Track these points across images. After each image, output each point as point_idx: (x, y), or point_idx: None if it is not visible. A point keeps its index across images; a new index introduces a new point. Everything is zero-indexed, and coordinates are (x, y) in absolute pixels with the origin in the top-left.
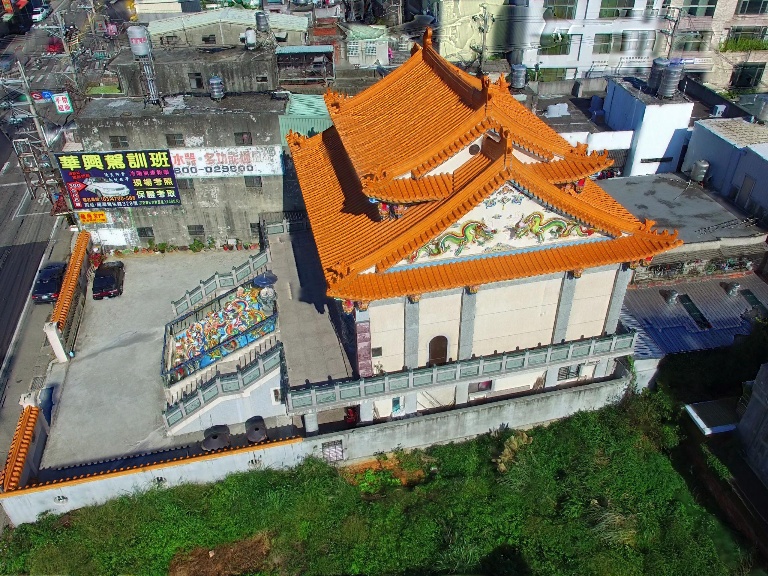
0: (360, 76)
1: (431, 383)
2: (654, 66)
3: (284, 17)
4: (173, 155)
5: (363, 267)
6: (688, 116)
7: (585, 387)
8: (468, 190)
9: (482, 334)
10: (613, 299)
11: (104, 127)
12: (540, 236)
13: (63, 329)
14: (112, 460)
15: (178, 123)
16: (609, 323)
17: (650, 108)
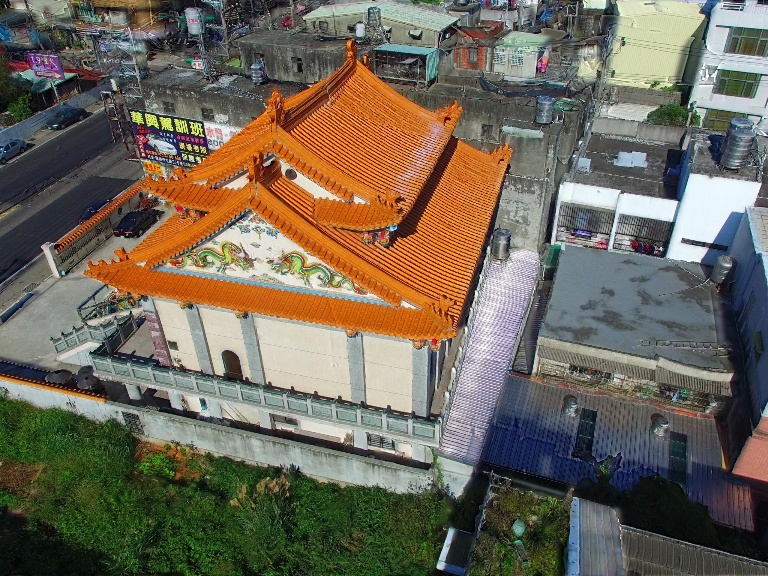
0: (462, 84)
1: (215, 394)
2: (730, 126)
3: (433, 15)
4: (207, 127)
5: (139, 259)
6: (752, 198)
7: (380, 462)
8: (220, 209)
9: (274, 364)
10: (413, 376)
11: (159, 92)
12: (309, 279)
13: (63, 251)
14: (11, 363)
15: (210, 99)
16: (415, 402)
17: (695, 177)
